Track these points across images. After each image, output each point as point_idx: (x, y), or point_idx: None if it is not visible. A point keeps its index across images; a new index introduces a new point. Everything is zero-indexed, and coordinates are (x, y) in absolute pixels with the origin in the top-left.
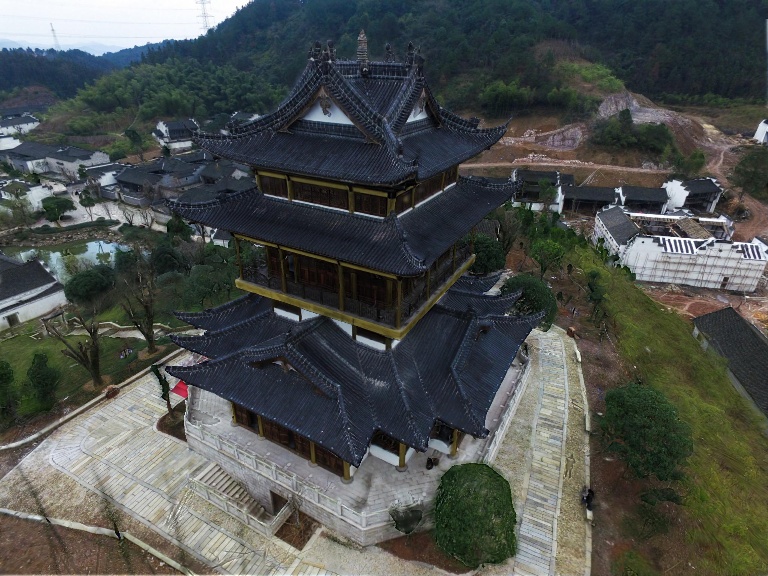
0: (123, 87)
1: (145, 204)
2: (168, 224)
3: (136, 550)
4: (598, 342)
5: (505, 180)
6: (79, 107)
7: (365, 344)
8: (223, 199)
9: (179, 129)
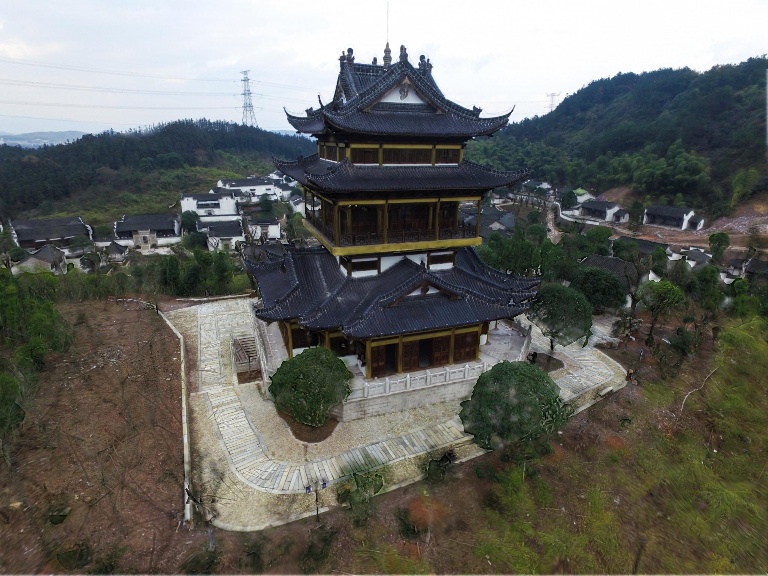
0: None
1: None
2: None
3: (178, 344)
4: (658, 395)
5: None
6: None
7: (342, 272)
8: (300, 160)
9: None
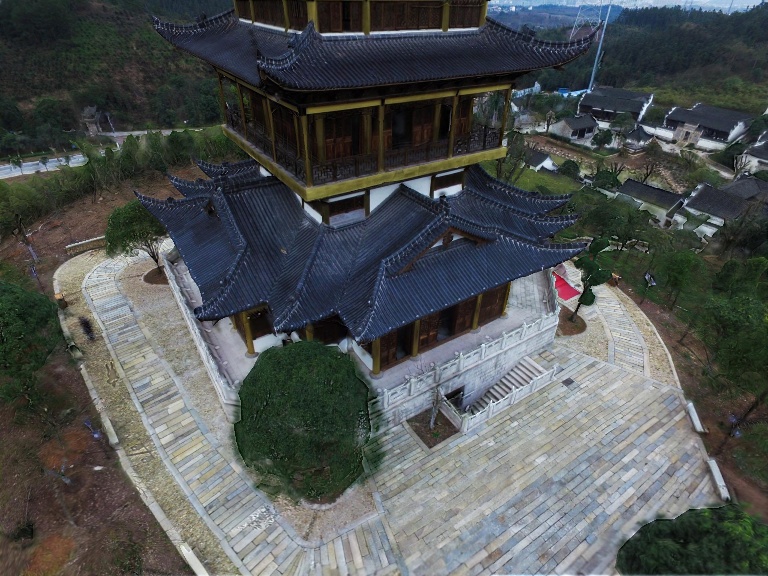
0: None
1: None
2: None
3: None
4: None
5: None
6: None
7: None
8: None
9: None
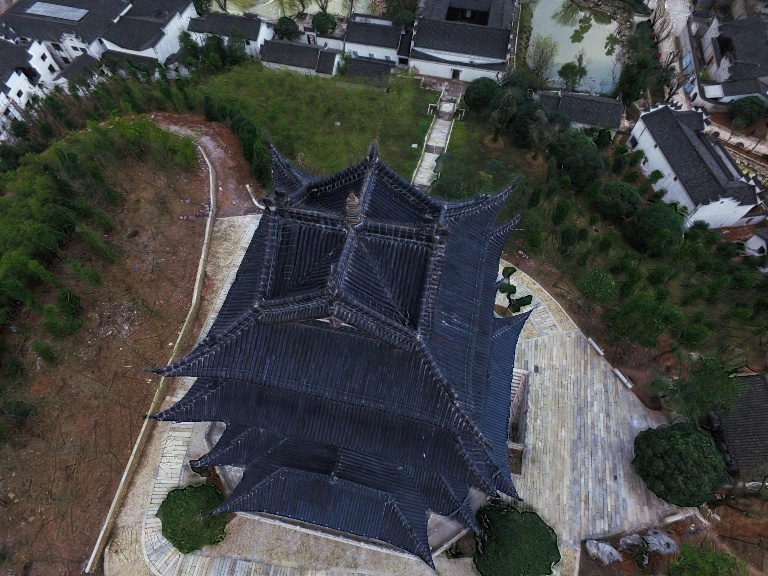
0: None
1: (705, 3)
2: (627, 67)
3: (185, 315)
4: None
5: None
6: None
7: None
8: None
9: None
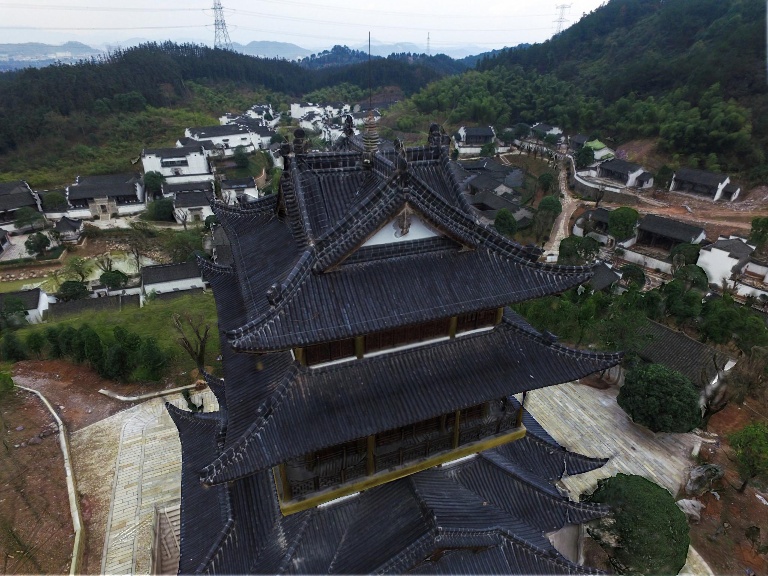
0: (446, 92)
1: None
2: None
3: (69, 550)
4: None
5: None
6: (410, 107)
7: None
8: None
9: (476, 135)
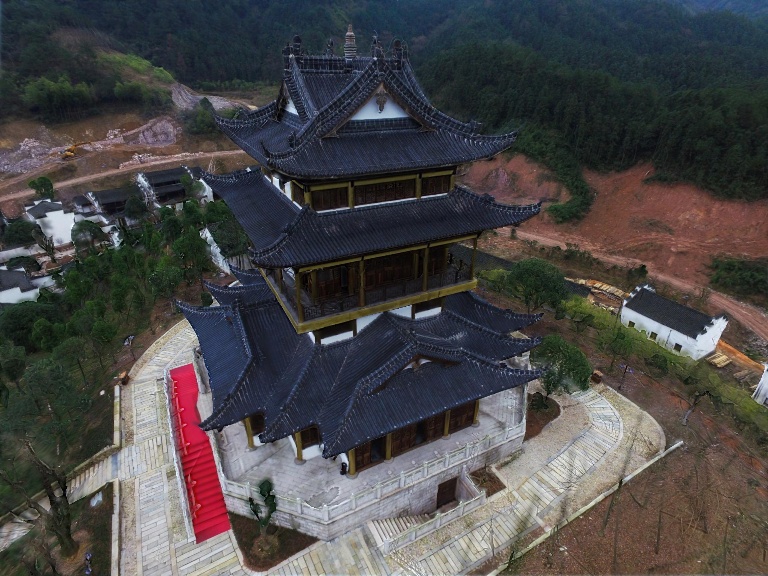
0: None
1: None
2: None
3: None
4: None
5: (135, 187)
6: None
7: (423, 317)
8: (290, 231)
9: None
